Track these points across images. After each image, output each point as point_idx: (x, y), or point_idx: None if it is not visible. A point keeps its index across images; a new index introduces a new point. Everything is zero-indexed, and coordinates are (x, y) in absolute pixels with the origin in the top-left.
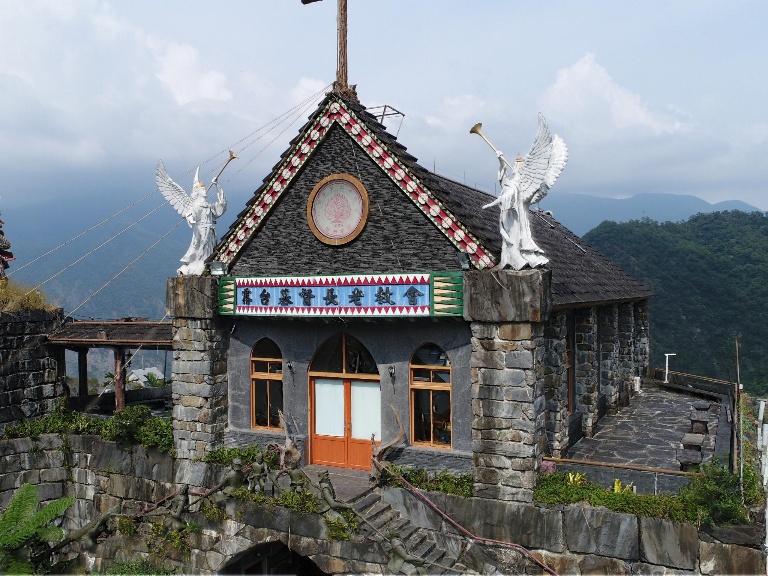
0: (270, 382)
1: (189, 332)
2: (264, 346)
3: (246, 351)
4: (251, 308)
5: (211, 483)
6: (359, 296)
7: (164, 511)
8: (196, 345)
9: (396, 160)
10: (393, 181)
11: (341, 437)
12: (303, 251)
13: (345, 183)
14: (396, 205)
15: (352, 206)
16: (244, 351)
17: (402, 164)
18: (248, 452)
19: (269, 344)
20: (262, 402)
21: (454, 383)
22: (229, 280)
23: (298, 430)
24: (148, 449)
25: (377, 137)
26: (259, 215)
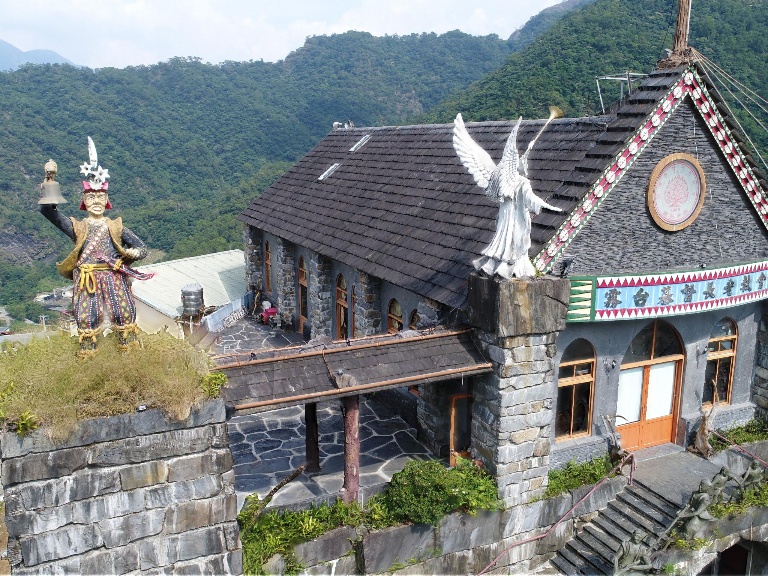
0: (578, 386)
1: (529, 352)
2: (574, 348)
3: (557, 358)
4: (621, 312)
5: (550, 520)
6: (731, 287)
7: (620, 571)
8: (539, 366)
9: (736, 146)
10: (728, 166)
11: (637, 422)
12: (637, 238)
13: (686, 164)
14: (725, 190)
15: (691, 189)
16: (554, 359)
17: (741, 150)
18: (573, 470)
19: (581, 345)
20: (557, 410)
21: (740, 349)
22: (583, 280)
23: (608, 429)
24: (465, 514)
25: (726, 119)
26: (600, 196)
